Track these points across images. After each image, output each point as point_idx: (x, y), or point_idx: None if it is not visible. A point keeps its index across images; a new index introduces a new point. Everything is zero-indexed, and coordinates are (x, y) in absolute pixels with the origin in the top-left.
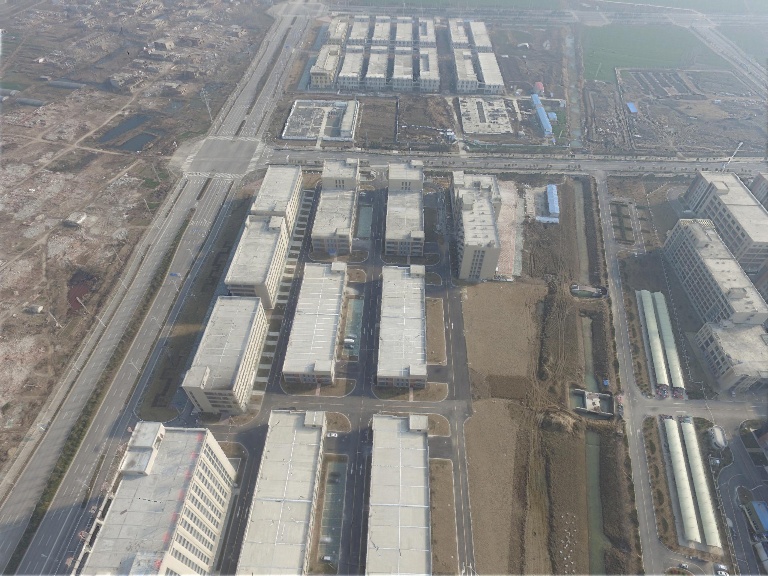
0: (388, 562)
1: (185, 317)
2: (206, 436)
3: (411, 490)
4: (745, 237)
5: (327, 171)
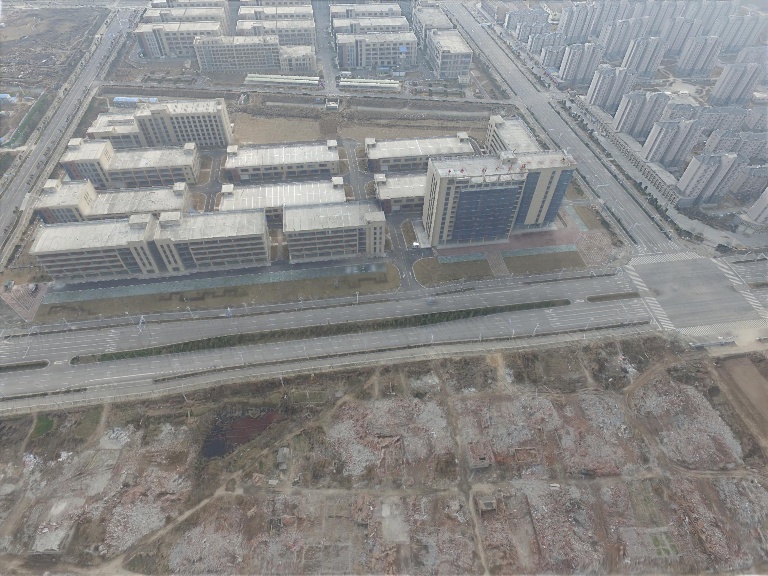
0: (448, 148)
1: (286, 296)
2: (433, 159)
3: (410, 144)
4: (211, 33)
5: (62, 204)
